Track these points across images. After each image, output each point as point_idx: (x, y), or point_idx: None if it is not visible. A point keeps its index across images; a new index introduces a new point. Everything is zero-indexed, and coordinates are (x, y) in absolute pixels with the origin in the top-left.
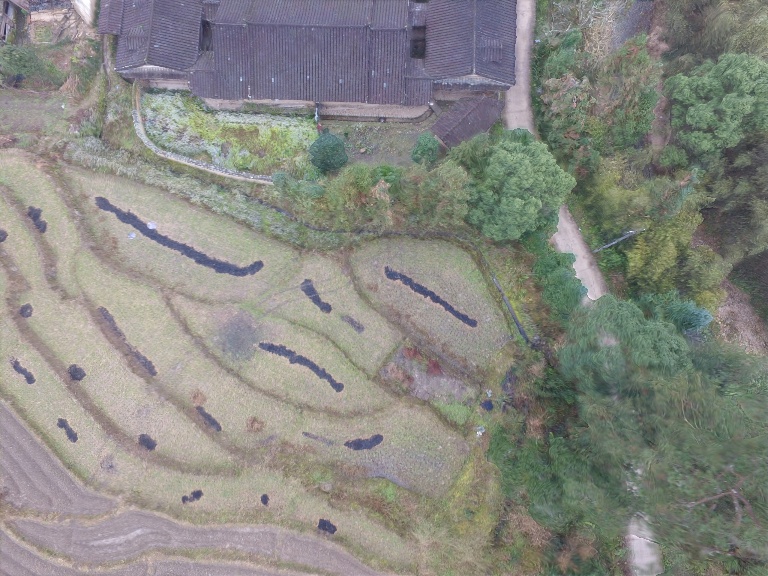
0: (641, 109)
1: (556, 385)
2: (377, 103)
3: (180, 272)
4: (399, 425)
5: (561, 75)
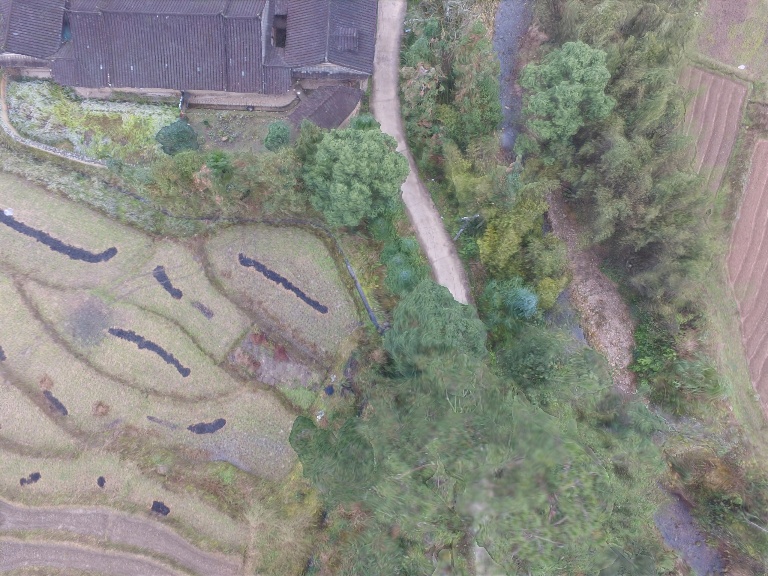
0: (482, 97)
1: (392, 370)
2: (236, 91)
3: (35, 258)
4: (242, 409)
5: None
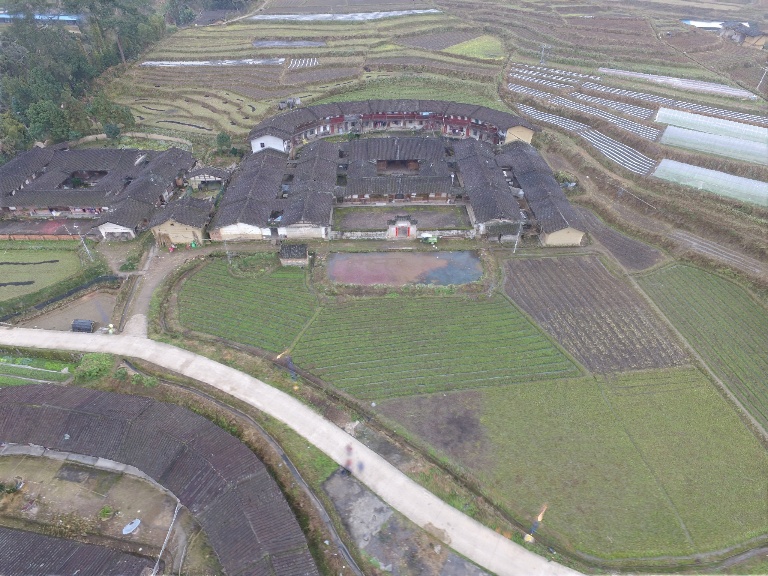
0: None
1: None
2: None
3: None
4: None
5: (1, 153)
